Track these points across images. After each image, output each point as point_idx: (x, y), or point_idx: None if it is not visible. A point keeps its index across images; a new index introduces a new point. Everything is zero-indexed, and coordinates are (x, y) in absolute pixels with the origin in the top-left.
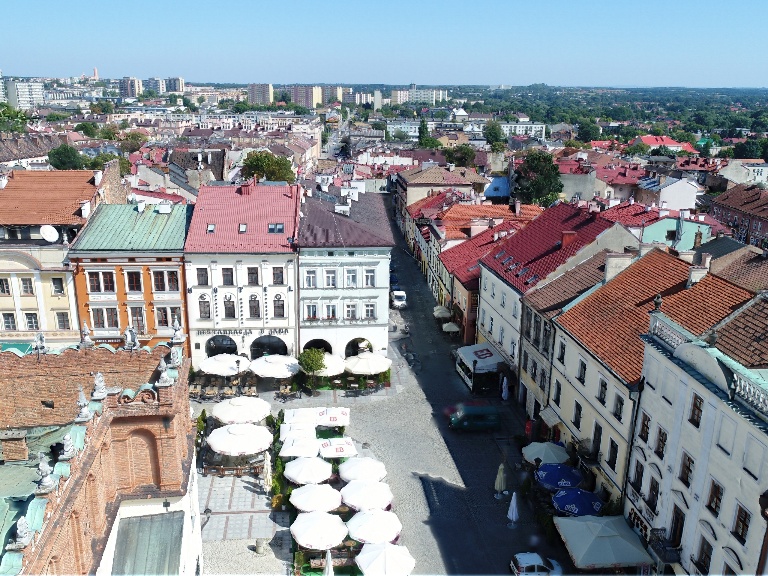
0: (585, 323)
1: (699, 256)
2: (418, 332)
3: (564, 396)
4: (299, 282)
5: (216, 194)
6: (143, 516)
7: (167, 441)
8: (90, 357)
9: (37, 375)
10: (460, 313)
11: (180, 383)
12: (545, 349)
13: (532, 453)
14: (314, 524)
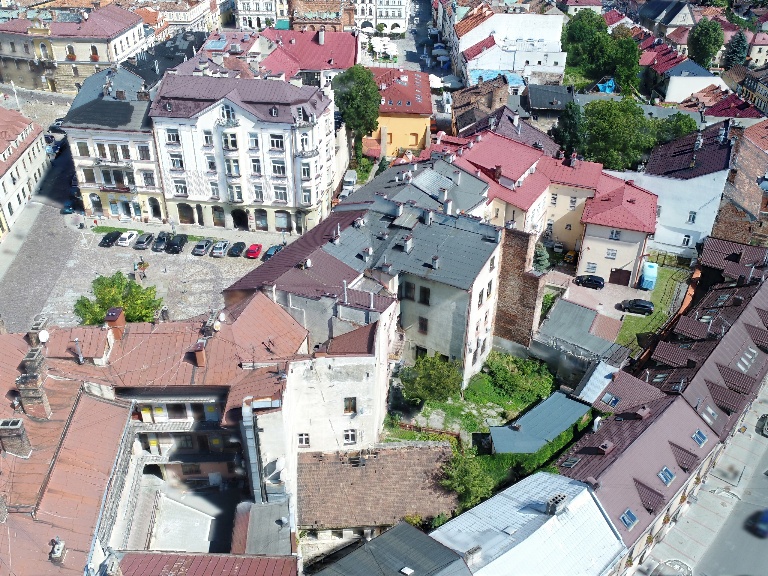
0: None
1: None
2: (420, 30)
3: None
4: (377, 3)
5: None
6: (348, 30)
7: (353, 14)
8: (336, 2)
9: (326, 5)
10: (434, 21)
11: (354, 6)
12: None
13: None
14: None
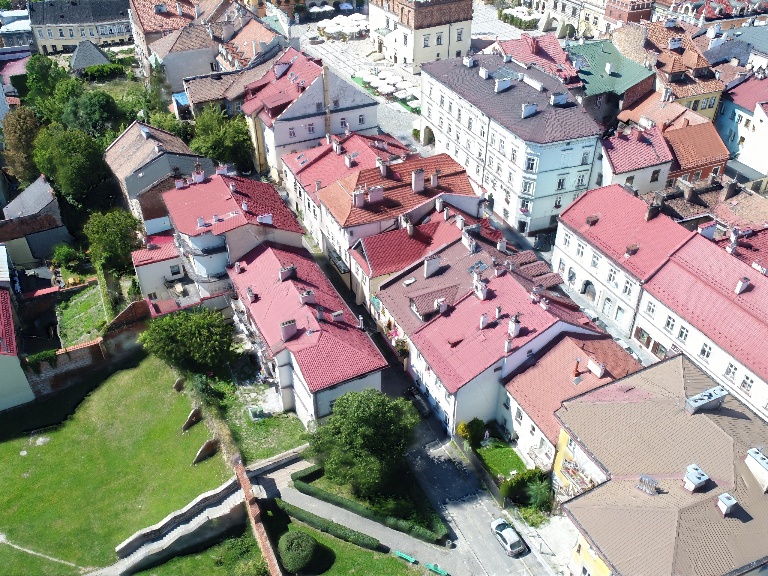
0: None
1: (206, 168)
2: None
3: None
4: None
5: None
6: None
7: None
8: None
9: None
10: None
11: None
12: None
13: None
14: None
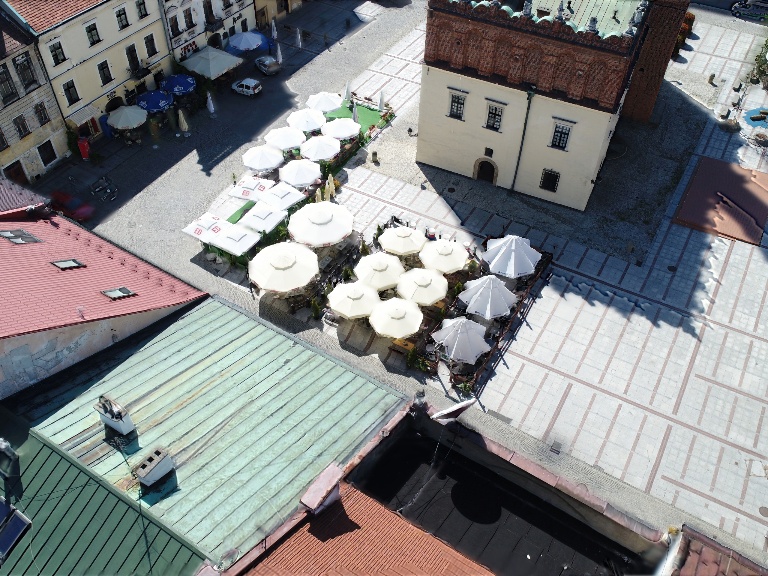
0: (57, 4)
1: None
2: None
3: (82, 82)
4: None
5: (4, 315)
6: None
7: None
8: None
9: None
10: None
11: None
12: (29, 84)
13: (140, 116)
14: (347, 121)
